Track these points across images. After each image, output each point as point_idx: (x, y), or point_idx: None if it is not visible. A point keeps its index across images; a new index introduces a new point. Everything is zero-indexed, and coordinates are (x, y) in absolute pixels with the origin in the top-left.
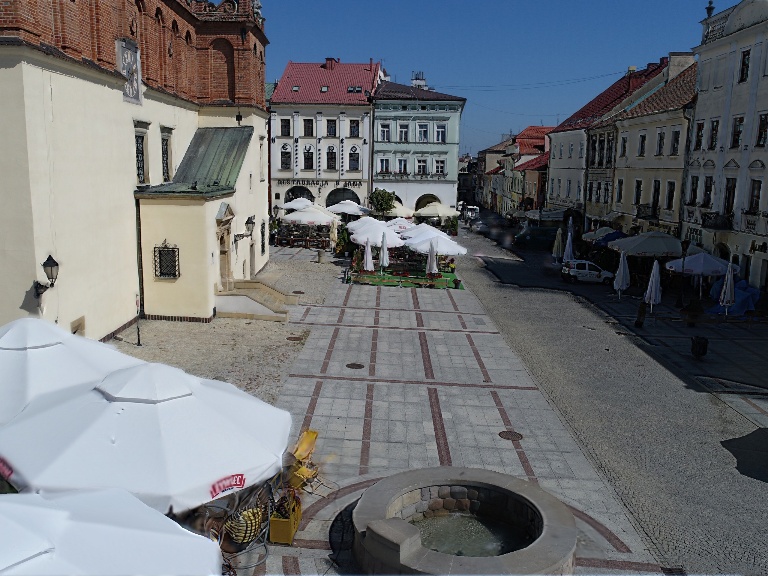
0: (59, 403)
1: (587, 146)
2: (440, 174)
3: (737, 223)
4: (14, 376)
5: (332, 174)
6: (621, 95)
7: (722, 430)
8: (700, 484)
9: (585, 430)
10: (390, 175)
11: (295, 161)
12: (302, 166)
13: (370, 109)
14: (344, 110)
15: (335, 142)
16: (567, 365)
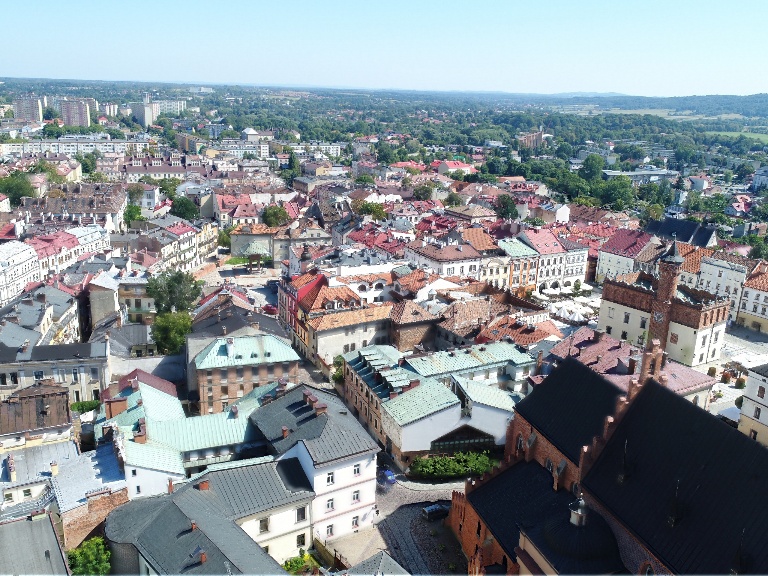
0: None
1: (634, 265)
2: None
3: None
4: (757, 357)
5: None
6: (633, 244)
7: None
8: None
9: (762, 352)
10: None
11: None
12: None
13: None
14: None
15: None
16: (740, 343)
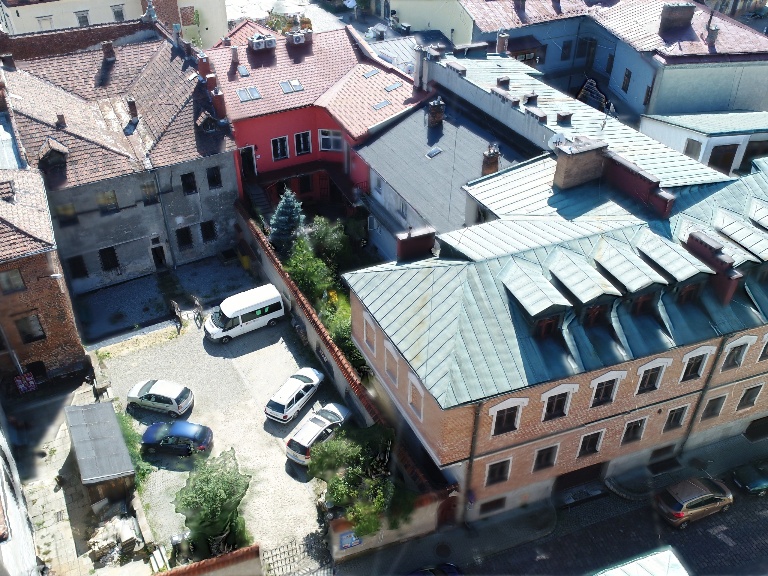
0: (241, 1)
1: None
2: None
3: None
4: None
5: None
6: None
7: None
8: None
9: None
10: None
11: None
12: None
13: None
14: None
15: None
16: None
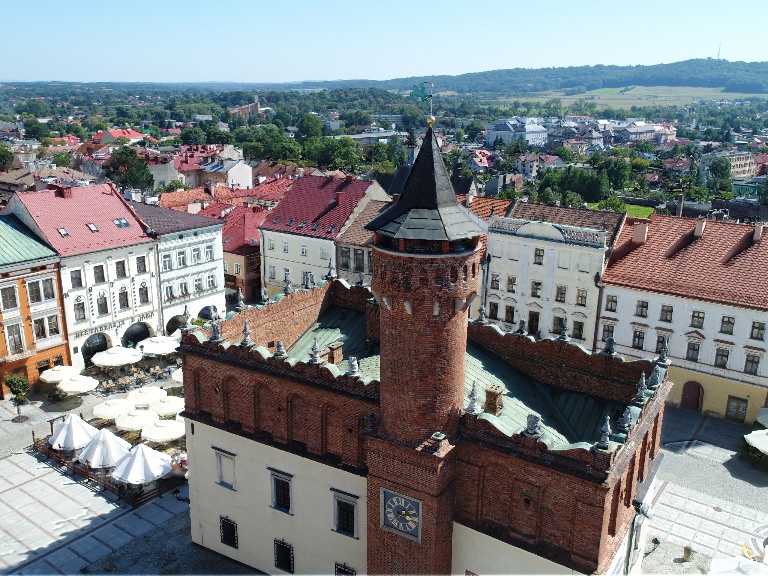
0: None
1: (337, 254)
2: (213, 287)
3: (545, 336)
4: None
5: (126, 313)
6: (331, 205)
7: (723, 471)
8: (764, 497)
9: None
10: (176, 299)
11: (91, 310)
12: (97, 313)
13: (154, 244)
14: (131, 250)
15: (126, 282)
16: None
